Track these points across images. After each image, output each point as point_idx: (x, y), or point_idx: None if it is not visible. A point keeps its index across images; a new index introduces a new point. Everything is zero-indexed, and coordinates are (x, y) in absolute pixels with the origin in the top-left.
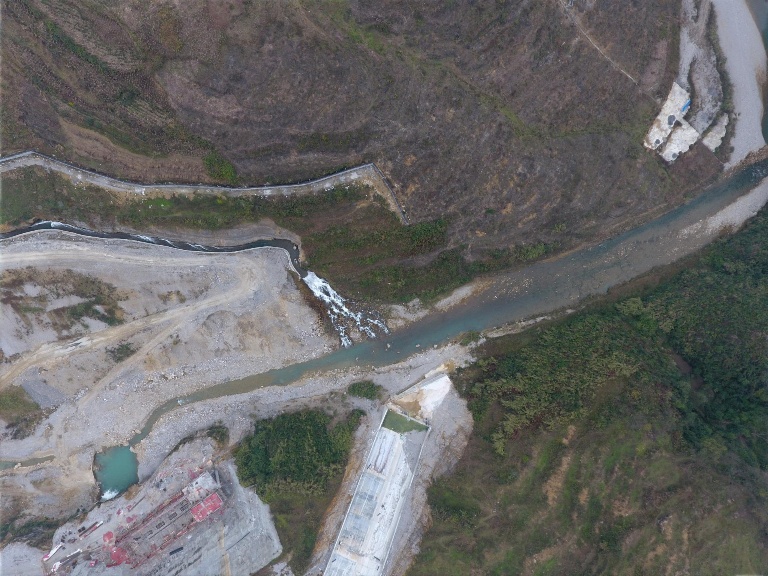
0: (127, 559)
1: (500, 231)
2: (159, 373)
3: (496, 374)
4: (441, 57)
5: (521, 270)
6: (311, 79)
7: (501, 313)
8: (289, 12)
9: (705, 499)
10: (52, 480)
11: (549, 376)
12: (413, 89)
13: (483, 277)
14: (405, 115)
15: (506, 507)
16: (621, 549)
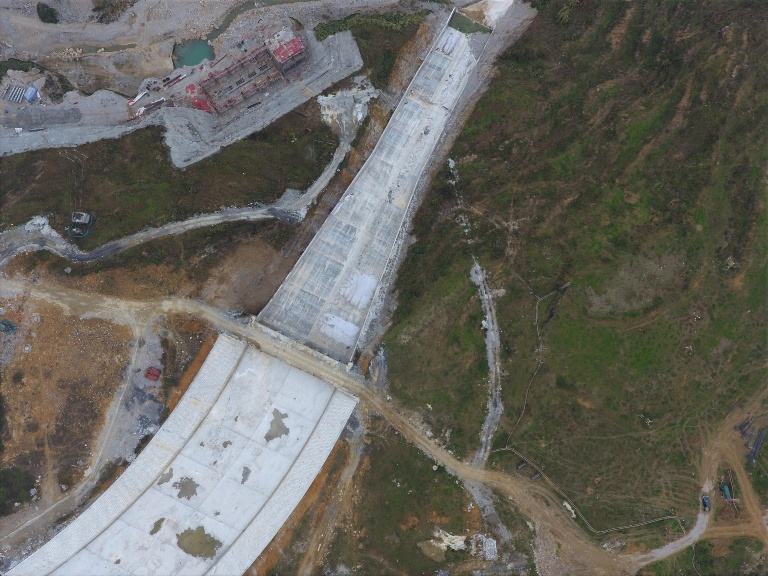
0: (208, 109)
1: None
2: None
3: None
4: None
5: None
6: None
7: None
8: None
9: (764, 13)
10: (133, 63)
11: None
12: None
13: None
14: None
15: (570, 57)
16: (683, 59)
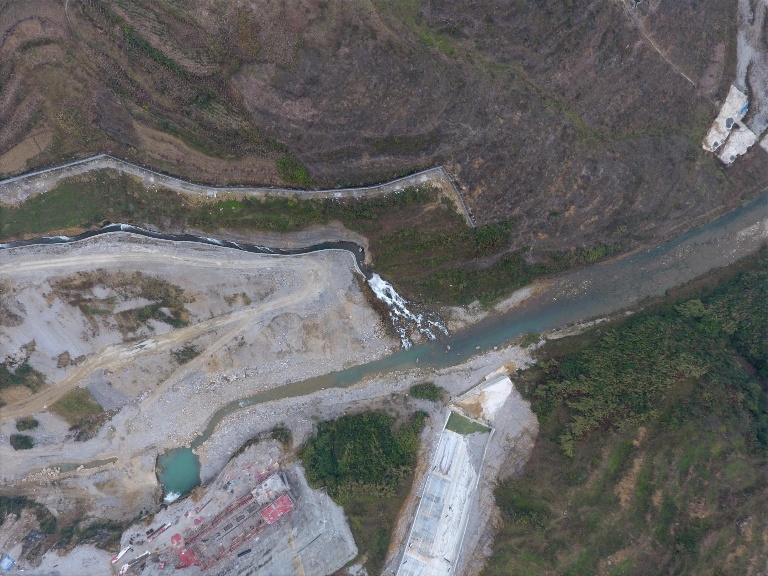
0: (195, 561)
1: (562, 233)
2: (221, 375)
3: (559, 376)
4: (510, 60)
5: (580, 272)
6: (386, 82)
7: (560, 315)
8: (363, 16)
9: None
10: (115, 482)
11: (614, 378)
12: (483, 92)
13: (542, 279)
14: (475, 118)
15: (577, 509)
16: (699, 551)
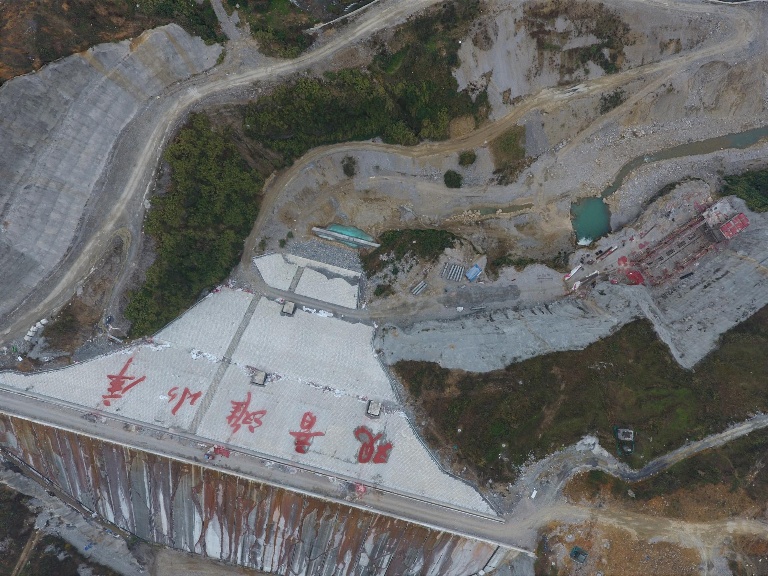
0: (642, 281)
1: None
2: (631, 130)
3: None
4: None
5: None
6: None
7: None
8: None
9: None
10: (534, 225)
11: None
12: None
13: None
14: None
15: None
16: None
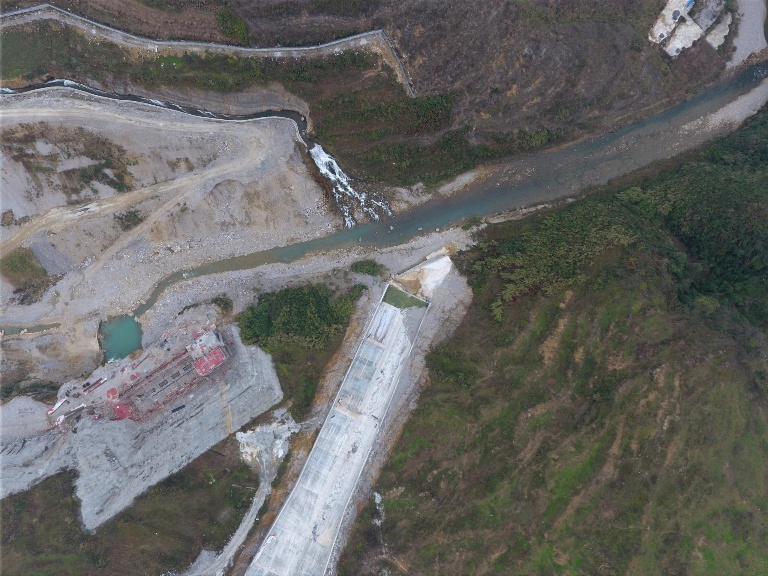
0: (130, 415)
1: (504, 114)
2: (165, 245)
3: (496, 253)
4: None
5: (524, 159)
6: None
7: (503, 200)
8: None
9: (697, 350)
10: (57, 346)
11: (548, 252)
12: None
13: (486, 164)
14: None
15: (503, 368)
16: (614, 398)
